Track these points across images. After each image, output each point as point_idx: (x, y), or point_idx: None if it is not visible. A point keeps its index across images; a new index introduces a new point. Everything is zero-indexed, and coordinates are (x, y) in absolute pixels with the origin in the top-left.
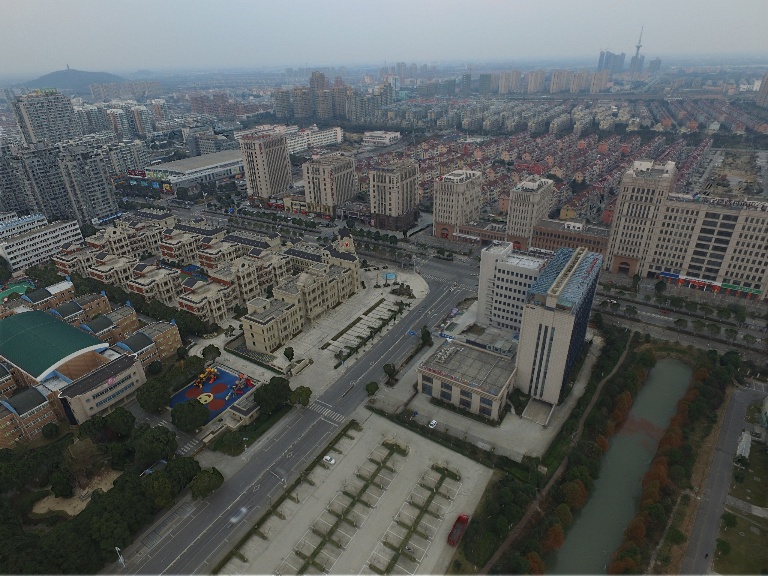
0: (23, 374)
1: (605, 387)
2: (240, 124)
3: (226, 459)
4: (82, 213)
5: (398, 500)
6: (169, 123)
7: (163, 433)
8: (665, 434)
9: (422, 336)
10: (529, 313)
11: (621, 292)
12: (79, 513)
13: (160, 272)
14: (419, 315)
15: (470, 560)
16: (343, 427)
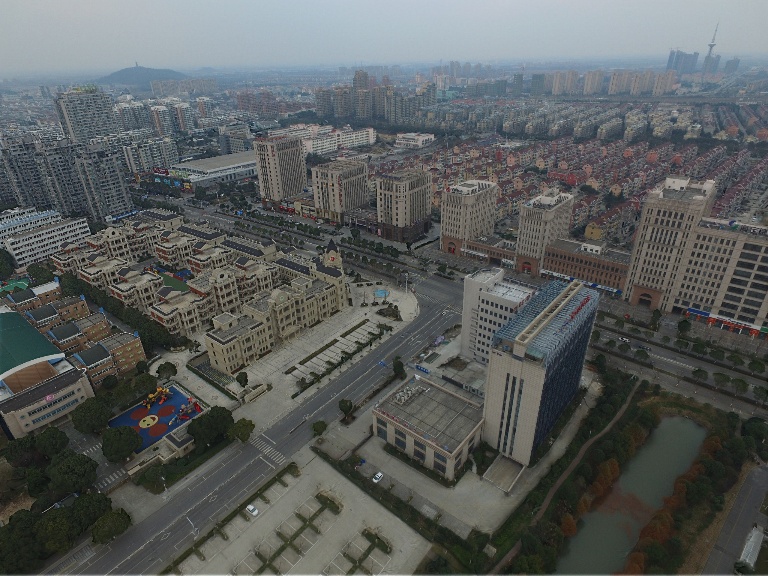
0: None
1: (591, 449)
2: (278, 123)
3: (146, 496)
4: (97, 210)
5: (313, 571)
6: (211, 120)
7: (81, 463)
8: (650, 521)
9: (394, 368)
10: (496, 360)
11: (635, 330)
12: None
13: (144, 277)
14: (400, 341)
15: None
16: (280, 470)
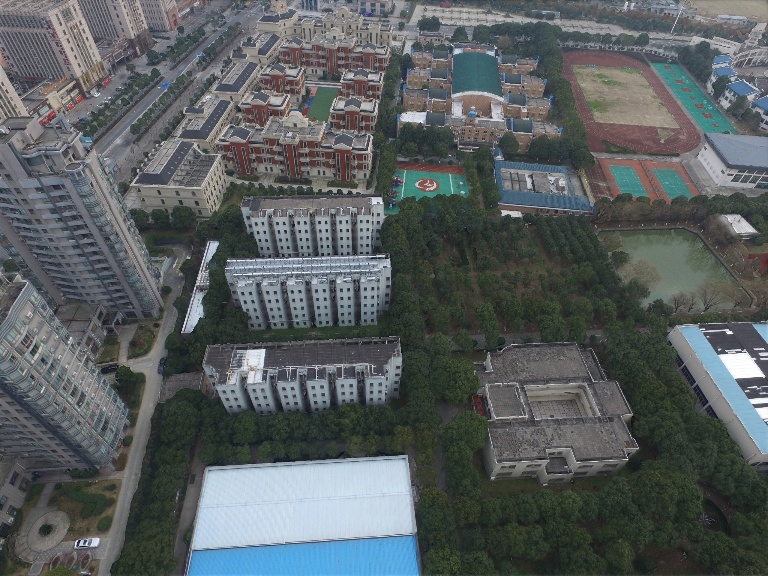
0: None
1: None
2: None
3: None
4: None
5: None
6: None
7: None
8: None
9: None
10: None
11: None
12: (521, 29)
13: None
14: None
15: (452, 5)
16: None
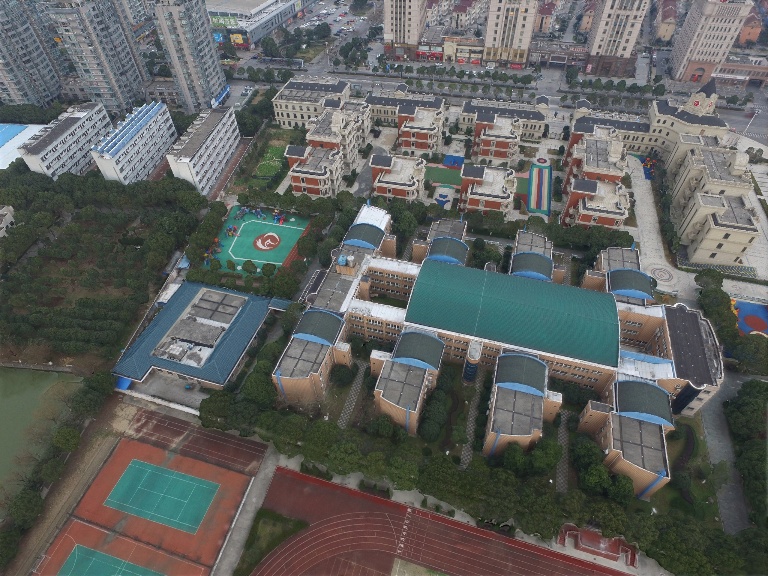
0: (555, 362)
1: None
2: None
3: None
4: (194, 93)
5: None
6: None
7: None
8: None
9: None
10: None
11: None
12: None
13: None
14: None
15: None
16: None
